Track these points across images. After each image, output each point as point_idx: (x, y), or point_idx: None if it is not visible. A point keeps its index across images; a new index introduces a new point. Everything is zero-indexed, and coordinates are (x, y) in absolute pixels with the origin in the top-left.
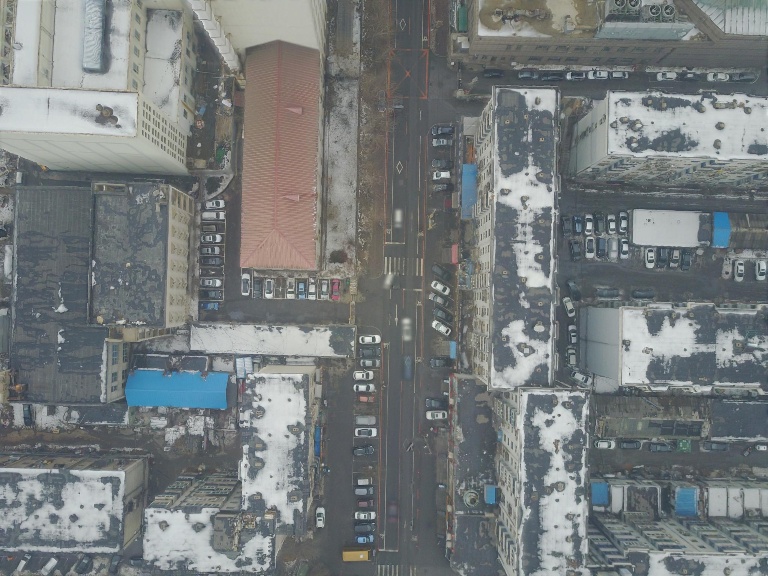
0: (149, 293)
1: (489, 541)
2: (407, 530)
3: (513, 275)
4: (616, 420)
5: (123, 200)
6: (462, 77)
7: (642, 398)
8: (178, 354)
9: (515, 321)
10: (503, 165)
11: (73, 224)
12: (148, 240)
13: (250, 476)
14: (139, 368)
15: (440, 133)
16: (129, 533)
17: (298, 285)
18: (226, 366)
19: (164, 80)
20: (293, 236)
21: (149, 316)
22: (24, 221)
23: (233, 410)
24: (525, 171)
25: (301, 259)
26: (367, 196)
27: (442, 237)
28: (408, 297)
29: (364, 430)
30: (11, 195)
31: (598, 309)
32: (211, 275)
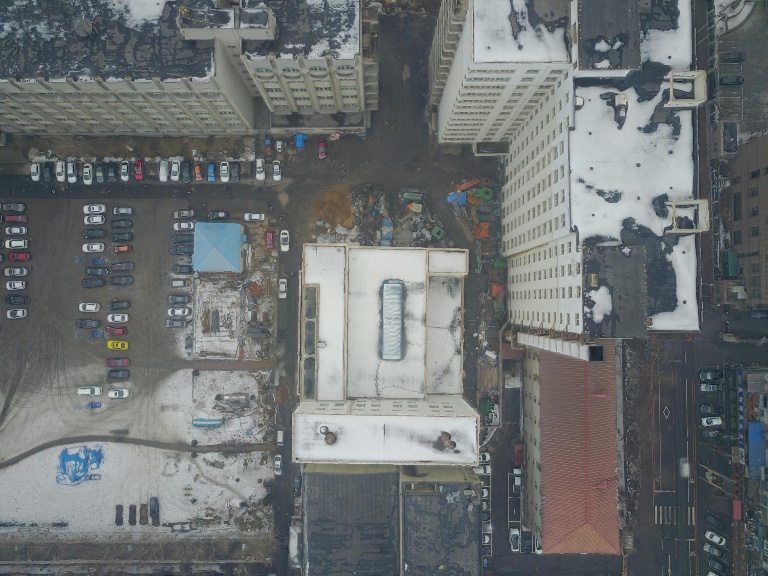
0: None
1: None
2: None
3: None
4: None
5: (433, 499)
6: (728, 318)
7: None
8: None
9: None
10: None
11: (366, 510)
12: (461, 541)
13: None
14: None
15: (709, 378)
16: None
17: None
18: None
19: (444, 349)
20: (602, 525)
21: None
22: (314, 507)
23: None
24: None
25: (608, 546)
26: (634, 443)
27: None
28: (681, 547)
29: None
30: (269, 452)
31: None
32: None
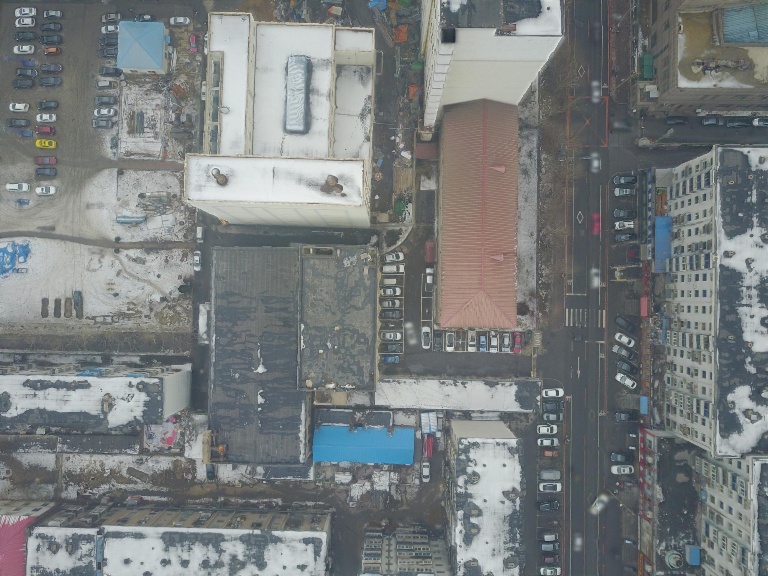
0: (358, 356)
1: None
2: None
3: (739, 340)
4: None
5: (330, 263)
6: (644, 125)
7: None
8: (360, 408)
9: (741, 387)
10: (726, 227)
11: (271, 284)
12: (356, 303)
13: (465, 542)
14: (324, 423)
15: (623, 182)
16: None
17: (479, 338)
18: (407, 420)
19: (354, 136)
20: (498, 296)
21: (358, 380)
22: (221, 281)
23: (416, 464)
24: (749, 233)
25: (504, 319)
26: (547, 247)
27: (625, 288)
28: (590, 349)
29: (550, 485)
30: (190, 249)
31: None
32: (390, 328)
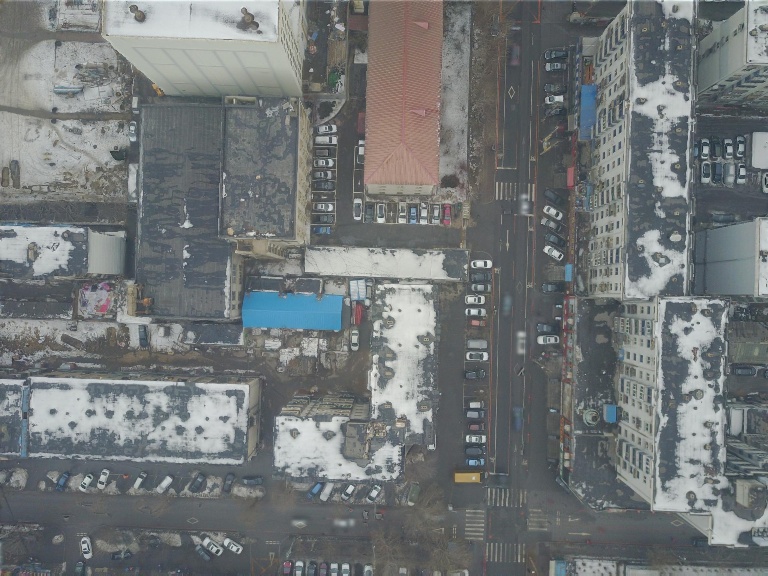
0: (278, 205)
1: (608, 461)
2: (517, 454)
3: (649, 185)
4: (733, 344)
5: (253, 113)
6: (576, 1)
7: (760, 323)
8: (291, 277)
9: (650, 231)
10: (639, 74)
11: (198, 141)
12: (278, 153)
13: (380, 386)
14: (254, 290)
15: (554, 57)
16: (249, 448)
17: (410, 209)
18: (338, 290)
19: None
20: (419, 151)
21: (278, 228)
22: (149, 138)
23: (345, 333)
24: (662, 80)
25: (426, 175)
26: (479, 121)
27: (554, 162)
28: (519, 222)
29: (476, 354)
30: (126, 120)
31: (723, 228)
32: (323, 200)
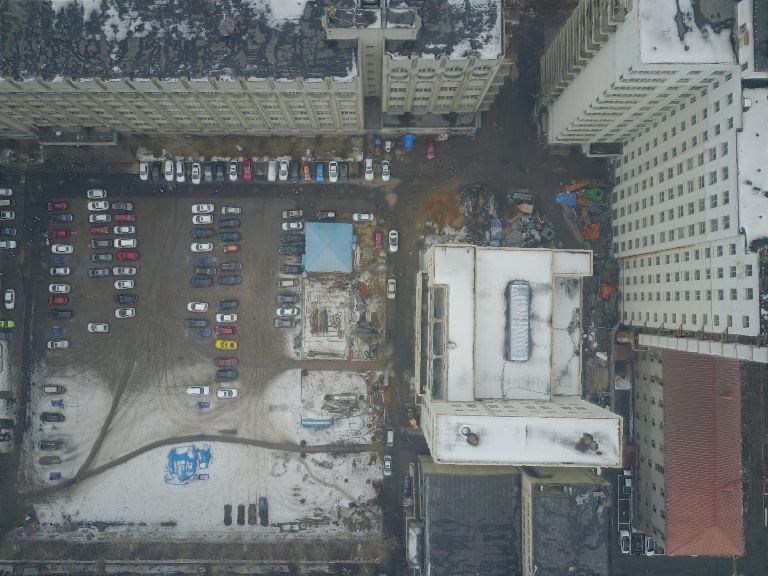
0: None
1: None
2: None
3: None
4: None
5: (562, 501)
6: None
7: None
8: None
9: None
10: None
11: (488, 511)
12: (590, 542)
13: None
14: None
15: None
16: None
17: None
18: None
19: (563, 351)
20: (729, 528)
21: None
22: (435, 508)
23: None
24: None
25: (733, 548)
26: (744, 445)
27: None
28: None
29: None
30: (378, 452)
31: None
32: None
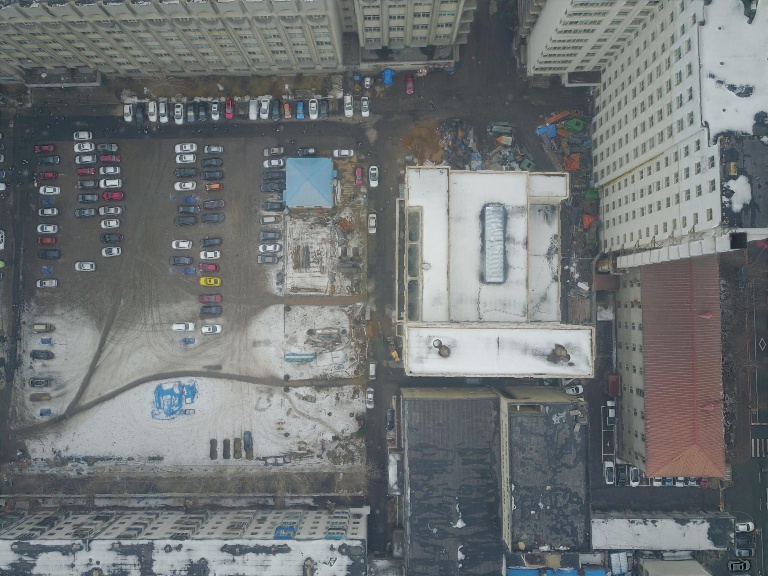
0: (571, 516)
1: None
2: None
3: None
4: None
5: (539, 420)
6: None
7: None
8: None
9: None
10: None
11: (467, 435)
12: (568, 461)
13: None
14: (511, 566)
15: None
16: None
17: None
18: (593, 558)
19: (541, 277)
20: (709, 448)
21: (572, 541)
22: (414, 433)
23: None
24: None
25: (714, 469)
26: (730, 375)
27: None
28: None
29: None
30: (361, 386)
31: None
32: None
